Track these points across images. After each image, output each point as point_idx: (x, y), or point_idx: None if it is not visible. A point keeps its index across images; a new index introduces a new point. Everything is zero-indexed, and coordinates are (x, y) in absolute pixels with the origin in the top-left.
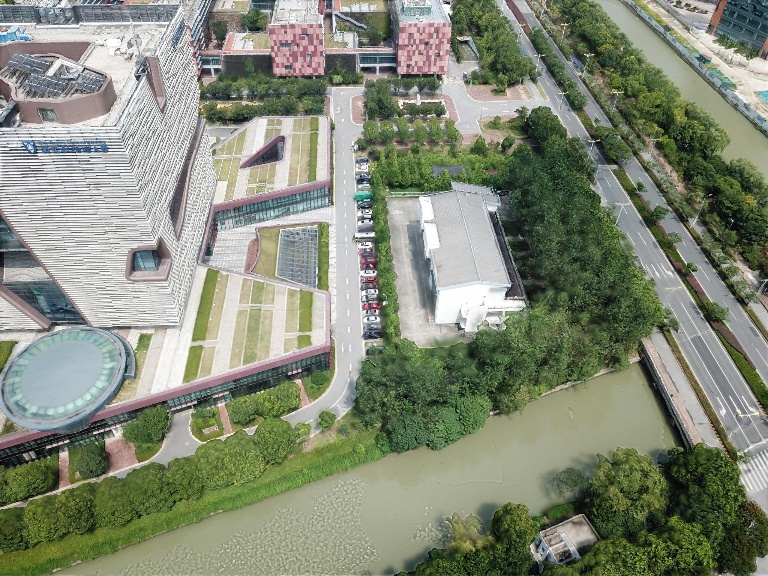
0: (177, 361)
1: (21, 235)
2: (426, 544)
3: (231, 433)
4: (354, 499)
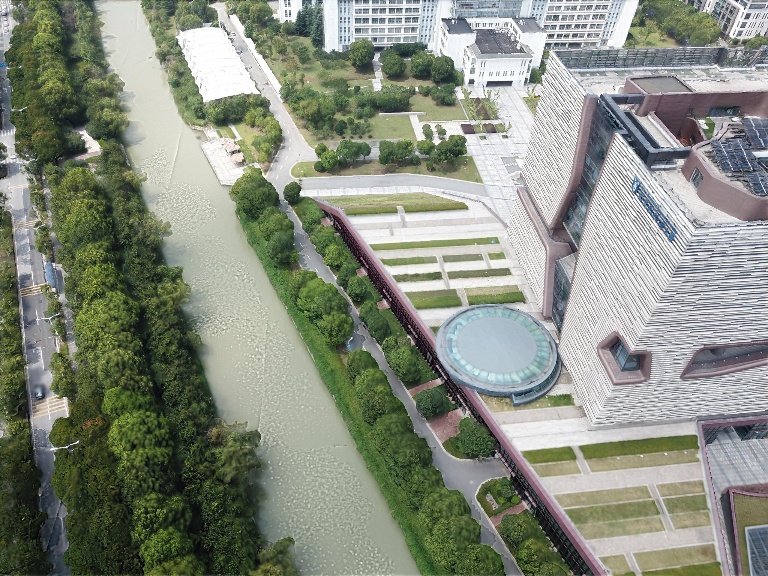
0: (547, 438)
1: (583, 241)
2: None
3: (493, 525)
4: None
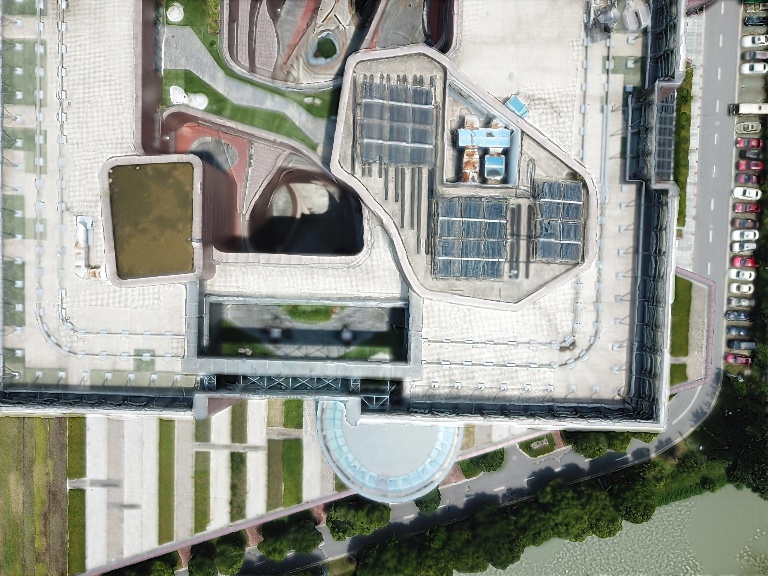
0: None
1: None
2: (756, 575)
3: (562, 448)
4: (687, 519)
